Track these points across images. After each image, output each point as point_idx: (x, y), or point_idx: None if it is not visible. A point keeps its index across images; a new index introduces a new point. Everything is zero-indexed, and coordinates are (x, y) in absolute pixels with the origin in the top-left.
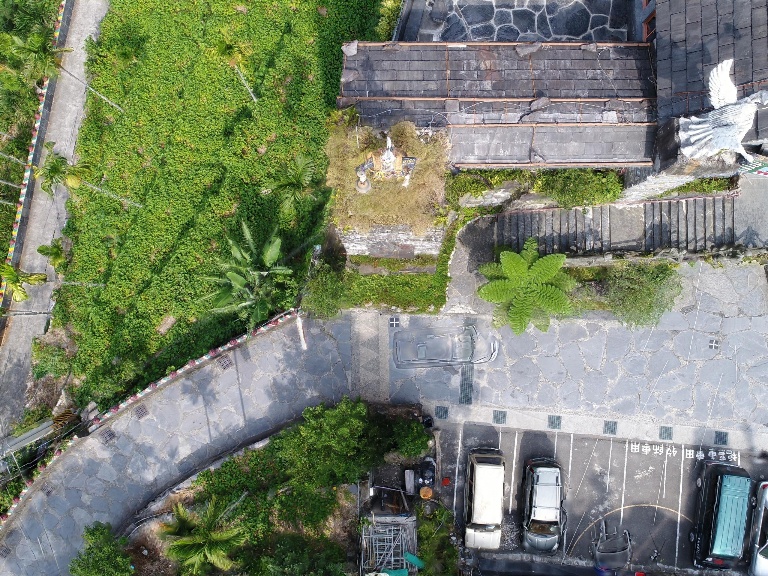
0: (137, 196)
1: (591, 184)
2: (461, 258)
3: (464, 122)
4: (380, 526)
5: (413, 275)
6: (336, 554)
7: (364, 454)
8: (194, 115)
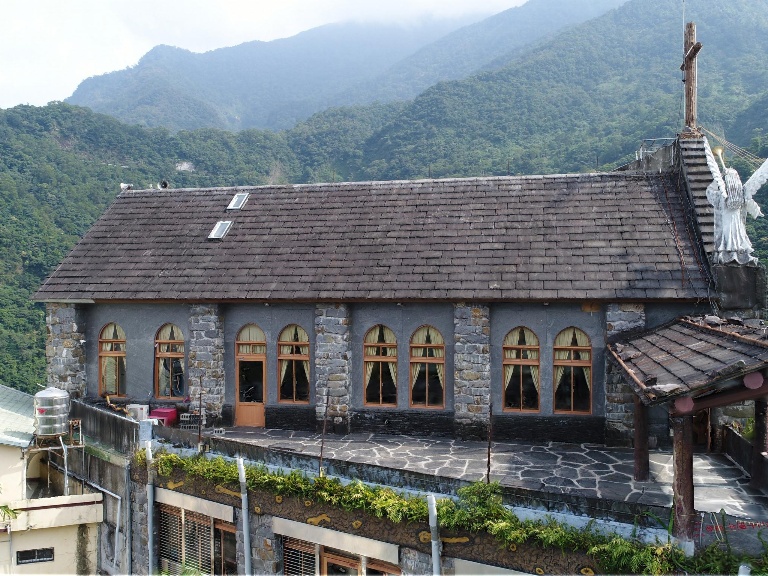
0: None
1: None
2: None
3: None
4: None
5: None
6: None
7: None
8: None
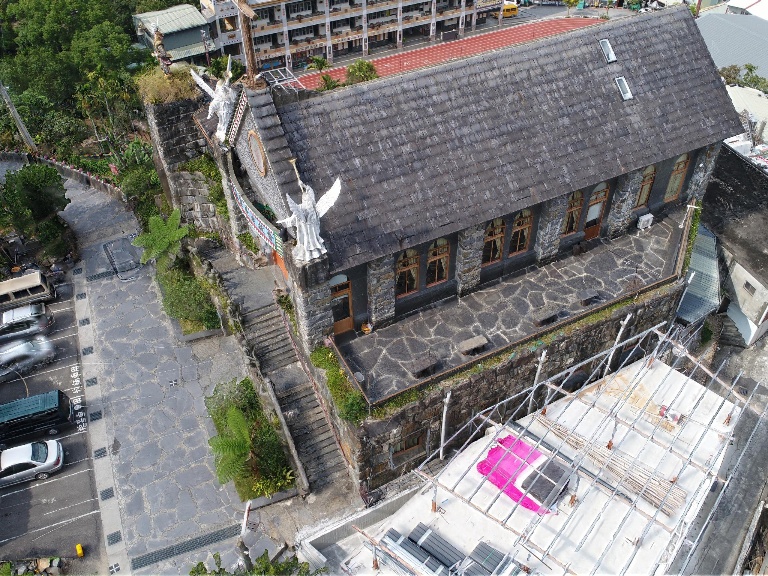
0: None
1: None
2: None
3: None
4: None
5: None
6: None
7: None
8: None
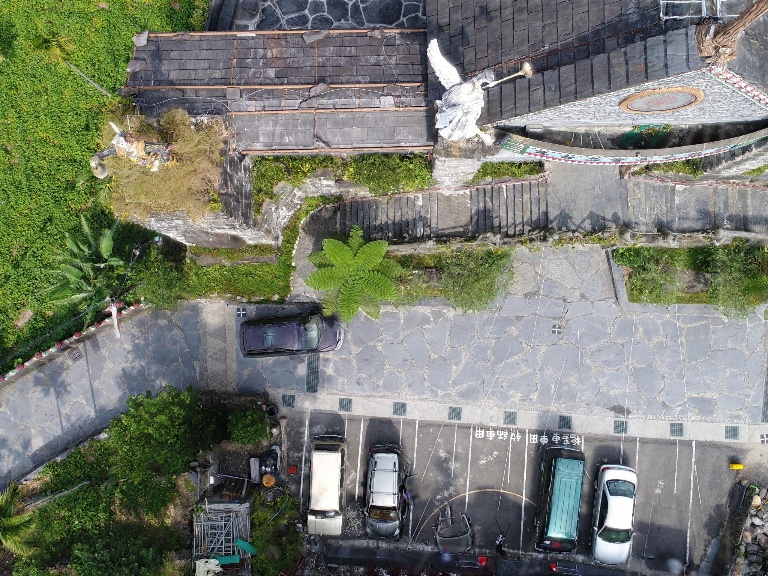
0: (4, 192)
1: (398, 170)
2: (305, 248)
3: (245, 109)
4: (212, 513)
5: (256, 265)
6: (173, 542)
7: (180, 441)
8: (56, 111)
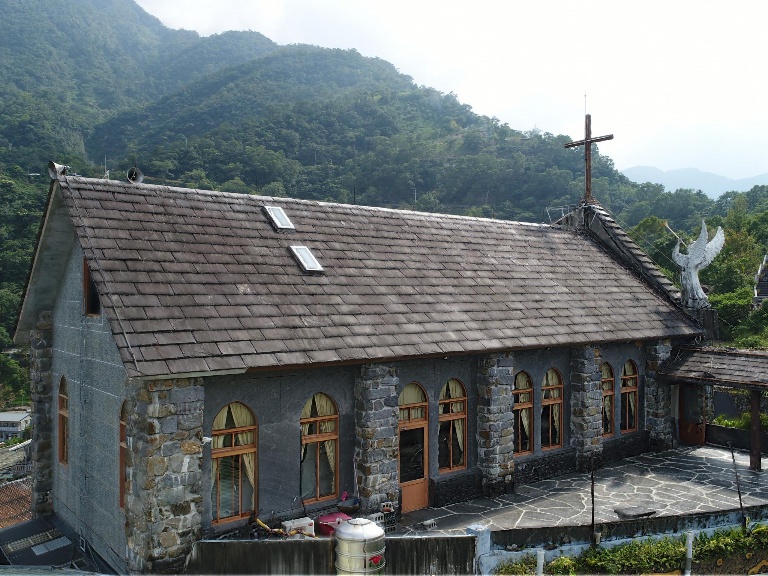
0: None
1: None
2: None
3: None
4: None
5: None
6: None
7: None
8: None
